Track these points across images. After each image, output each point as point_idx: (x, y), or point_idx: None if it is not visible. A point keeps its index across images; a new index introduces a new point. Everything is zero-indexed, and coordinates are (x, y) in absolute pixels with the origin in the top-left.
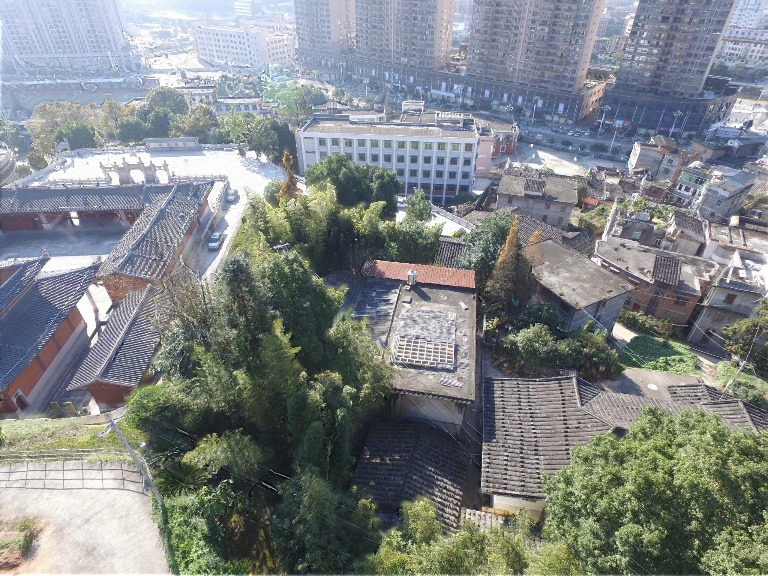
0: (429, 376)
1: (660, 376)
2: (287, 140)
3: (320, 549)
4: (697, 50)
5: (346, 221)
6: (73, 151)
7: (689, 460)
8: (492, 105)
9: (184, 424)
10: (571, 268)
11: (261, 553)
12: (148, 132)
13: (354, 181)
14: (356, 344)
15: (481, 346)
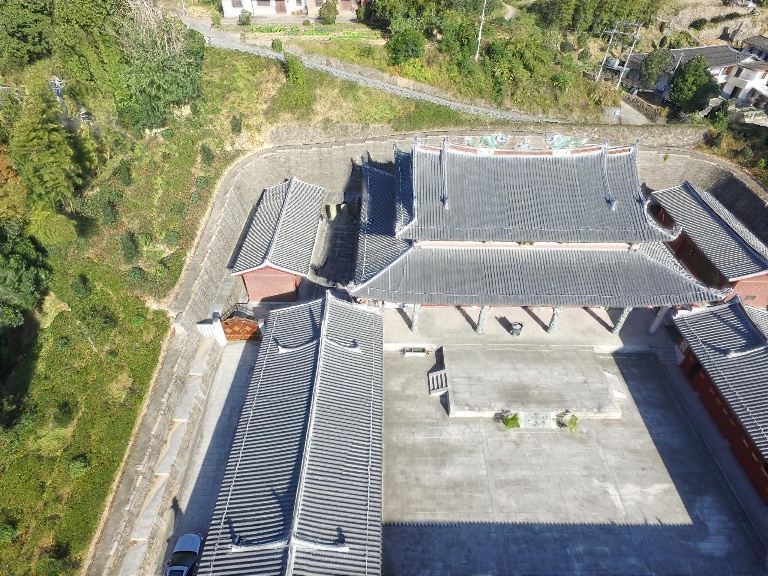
0: None
1: None
2: None
3: None
4: None
5: None
6: None
7: None
8: None
9: None
10: None
11: None
12: None
13: None
14: None
15: None
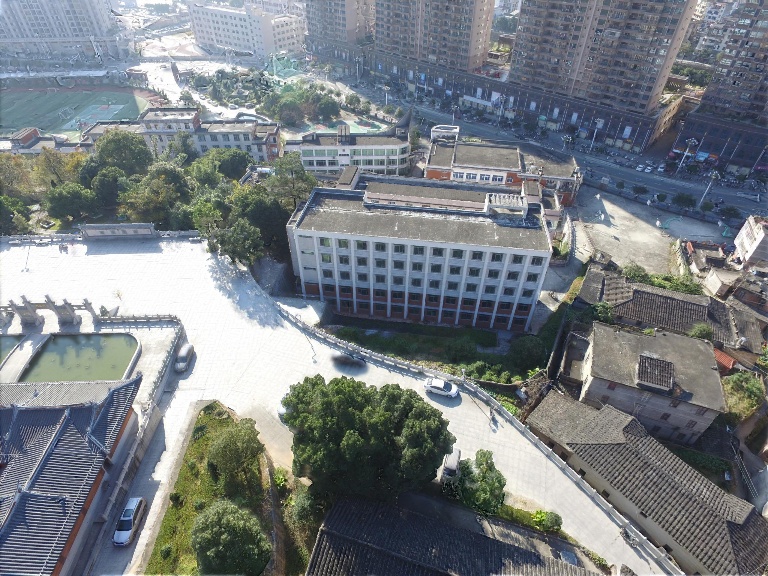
0: None
1: None
2: (277, 224)
3: None
4: None
5: None
6: None
7: None
8: (538, 120)
9: None
10: None
11: None
12: (91, 204)
13: (368, 450)
14: None
15: None
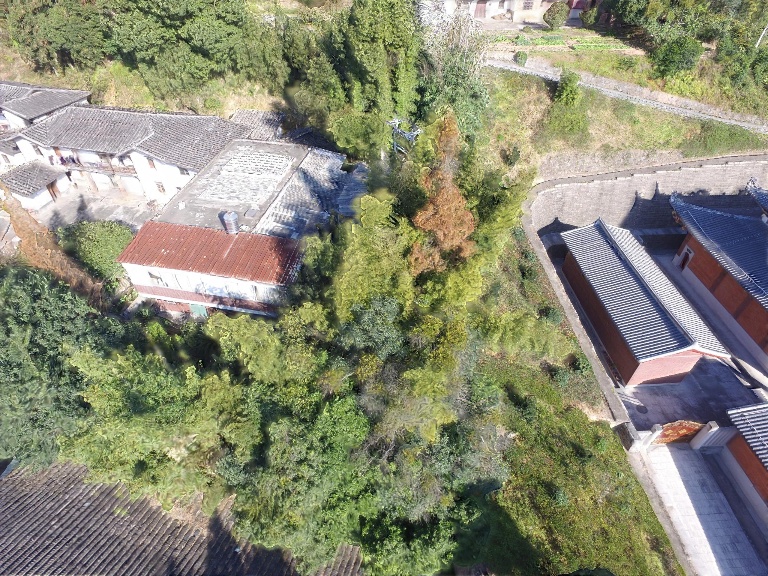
0: (263, 151)
1: None
2: None
3: None
4: None
5: None
6: None
7: None
8: None
9: None
10: None
11: None
12: None
13: None
14: None
15: None
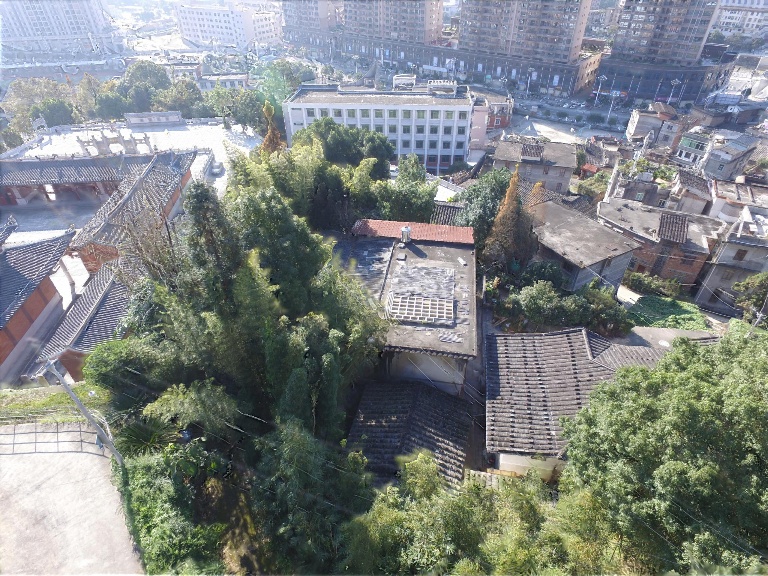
0: (427, 332)
1: (671, 332)
2: None
3: (305, 509)
4: (695, 15)
5: (334, 177)
6: (50, 128)
7: (740, 384)
8: (485, 79)
9: (150, 379)
10: (573, 228)
11: (241, 519)
12: (129, 108)
13: (343, 145)
14: (345, 291)
15: (481, 307)
